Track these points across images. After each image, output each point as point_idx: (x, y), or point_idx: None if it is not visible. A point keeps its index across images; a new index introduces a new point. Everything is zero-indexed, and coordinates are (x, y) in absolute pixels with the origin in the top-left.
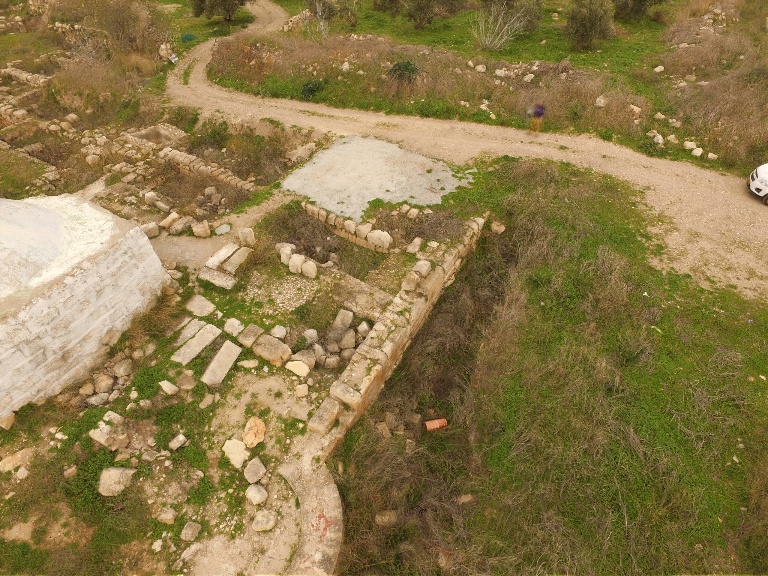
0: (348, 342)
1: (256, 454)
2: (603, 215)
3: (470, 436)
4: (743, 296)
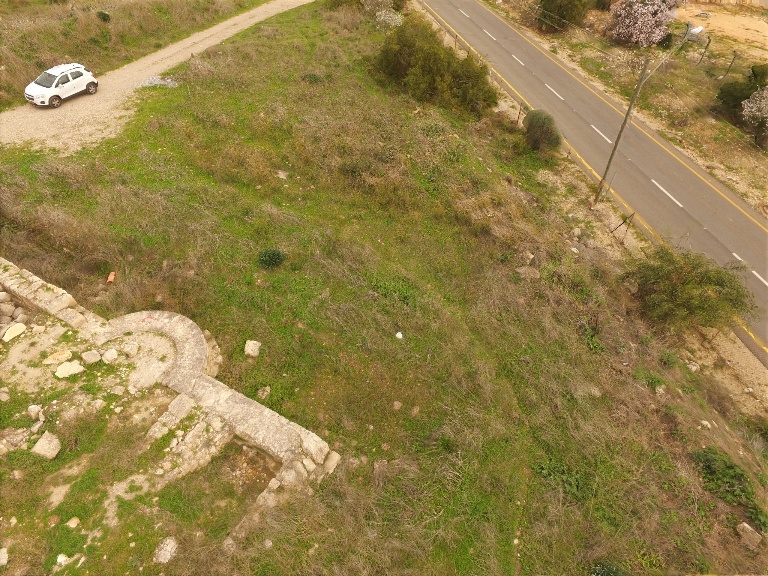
0: (8, 308)
1: (78, 356)
2: (0, 161)
3: (129, 259)
4: (112, 138)
